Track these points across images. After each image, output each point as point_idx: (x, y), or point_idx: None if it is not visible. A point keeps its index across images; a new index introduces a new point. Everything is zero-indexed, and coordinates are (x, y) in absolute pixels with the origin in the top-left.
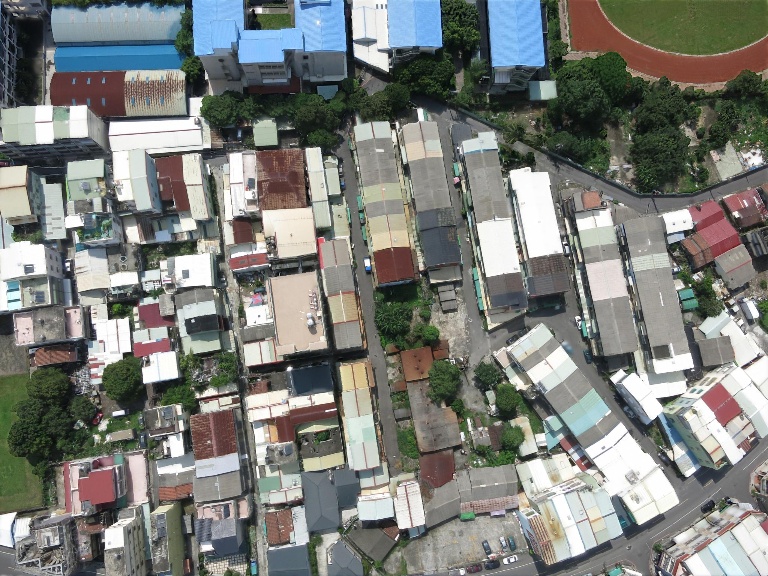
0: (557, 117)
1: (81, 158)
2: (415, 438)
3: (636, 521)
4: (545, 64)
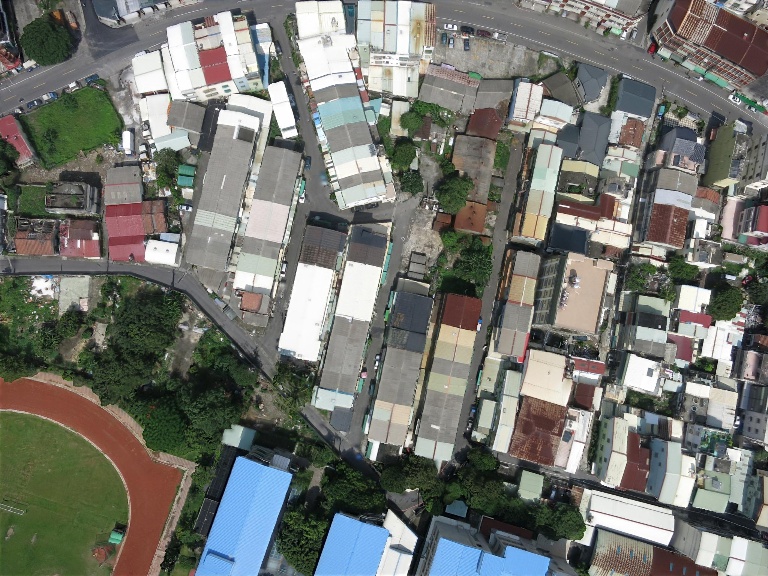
0: (237, 403)
1: (699, 521)
2: None
3: (342, 5)
4: (223, 464)
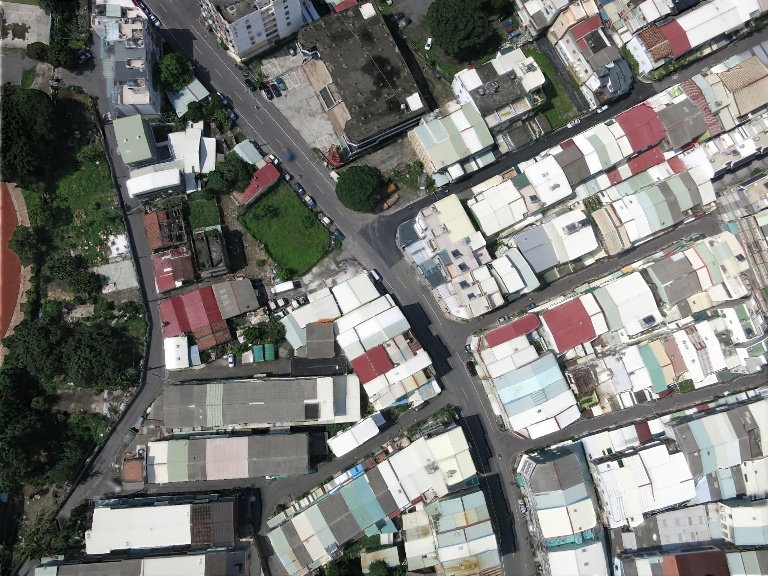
0: (33, 474)
1: None
2: None
3: None
4: None
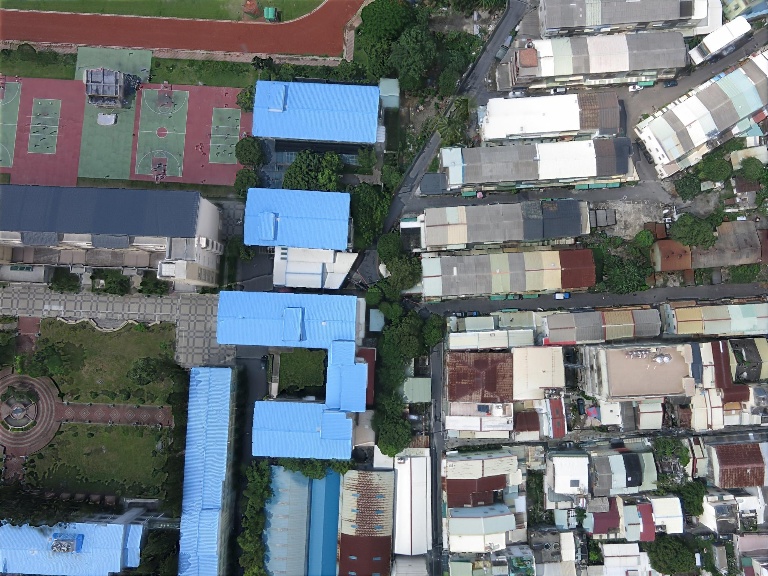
0: (421, 82)
1: None
2: (741, 266)
3: None
4: None
